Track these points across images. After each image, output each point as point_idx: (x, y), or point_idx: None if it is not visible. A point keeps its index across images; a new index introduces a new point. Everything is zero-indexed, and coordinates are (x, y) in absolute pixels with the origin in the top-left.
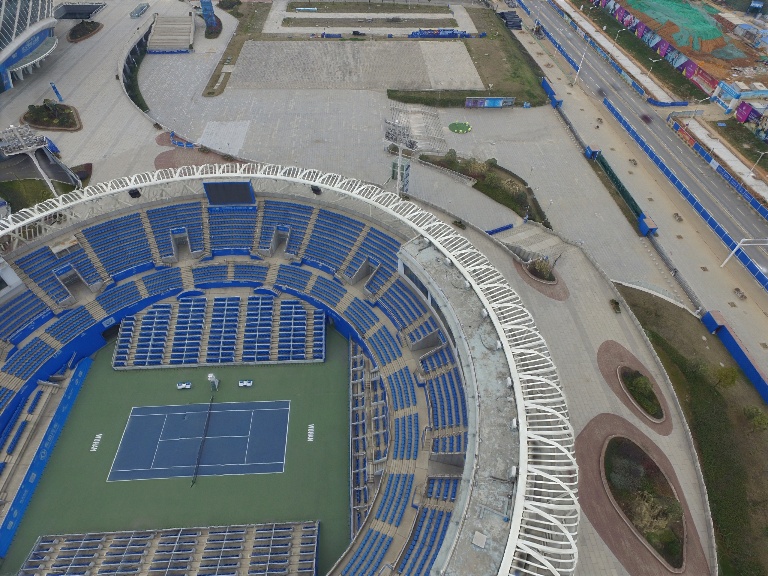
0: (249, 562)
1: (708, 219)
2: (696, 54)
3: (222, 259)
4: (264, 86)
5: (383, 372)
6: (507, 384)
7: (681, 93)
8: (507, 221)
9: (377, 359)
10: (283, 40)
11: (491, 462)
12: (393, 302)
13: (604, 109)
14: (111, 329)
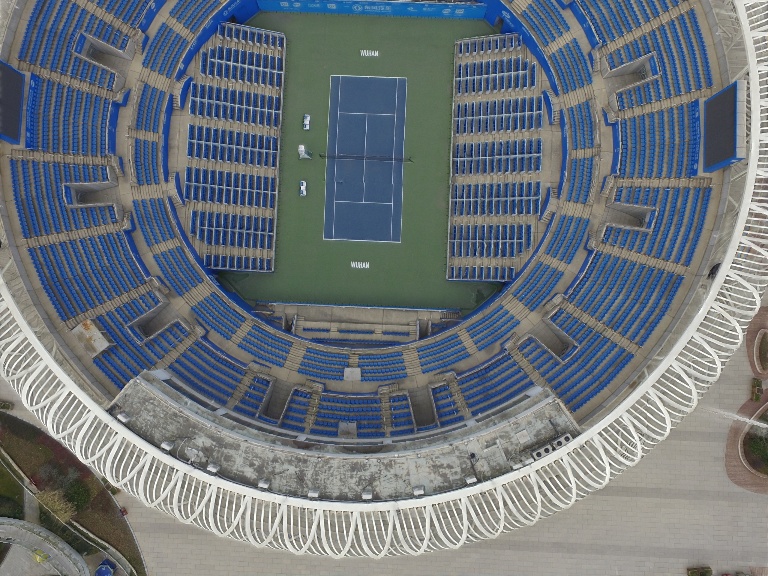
0: None
1: None
2: None
3: (122, 146)
4: None
5: None
6: None
7: None
8: None
9: None
10: None
11: None
12: None
13: None
14: None
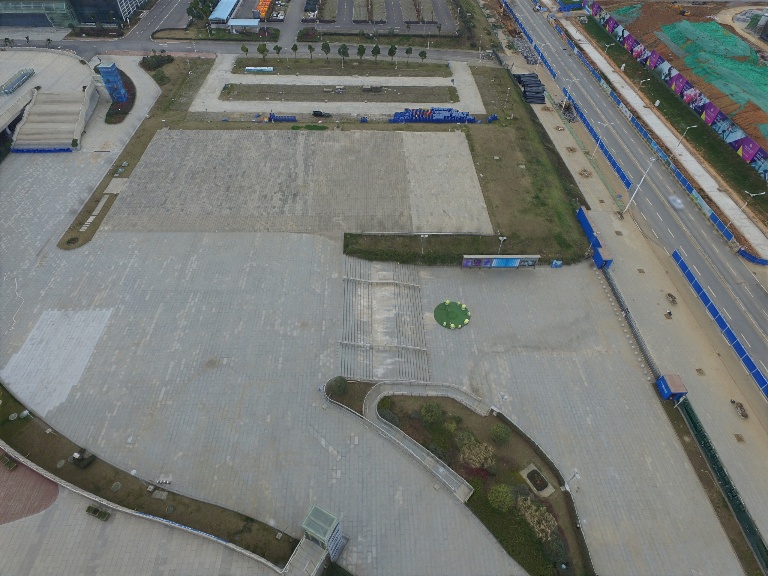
0: None
1: None
2: None
3: None
4: (158, 225)
5: None
6: None
7: None
8: None
9: None
10: (212, 128)
11: None
12: None
13: (674, 268)
14: None
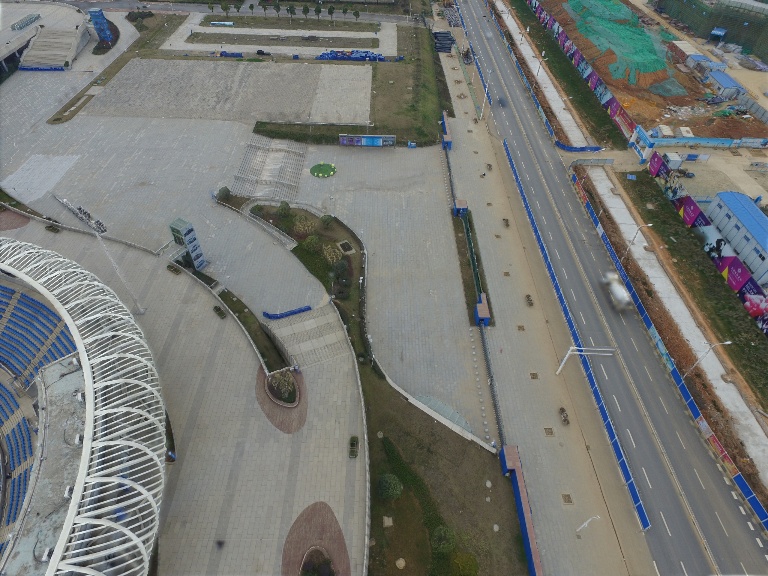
0: None
1: (563, 306)
2: (631, 88)
3: None
4: (121, 113)
5: (2, 535)
6: None
7: (599, 135)
8: (309, 300)
9: (6, 513)
10: (174, 59)
11: None
12: None
13: (502, 152)
14: None
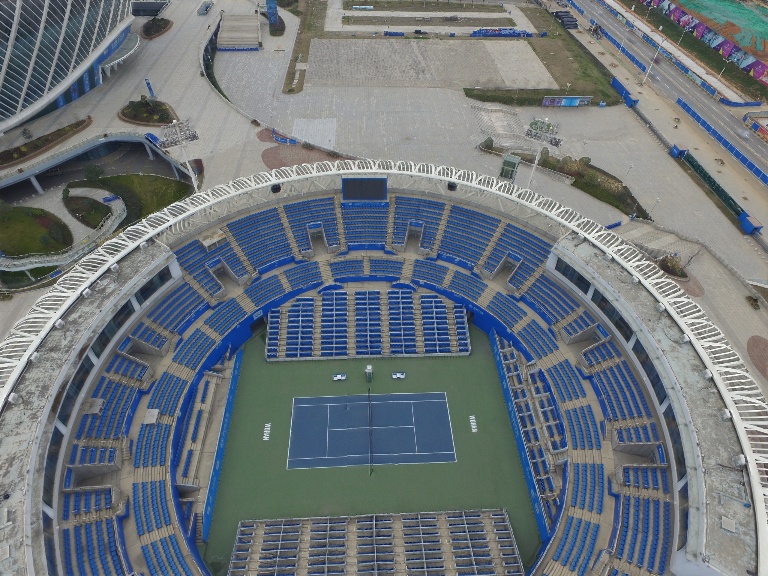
0: (450, 547)
1: None
2: (759, 55)
3: (357, 254)
4: (341, 84)
5: (540, 365)
6: (706, 376)
7: (751, 93)
8: (613, 219)
9: (531, 352)
10: (348, 38)
11: (714, 451)
12: (540, 297)
13: (678, 109)
14: (253, 322)
